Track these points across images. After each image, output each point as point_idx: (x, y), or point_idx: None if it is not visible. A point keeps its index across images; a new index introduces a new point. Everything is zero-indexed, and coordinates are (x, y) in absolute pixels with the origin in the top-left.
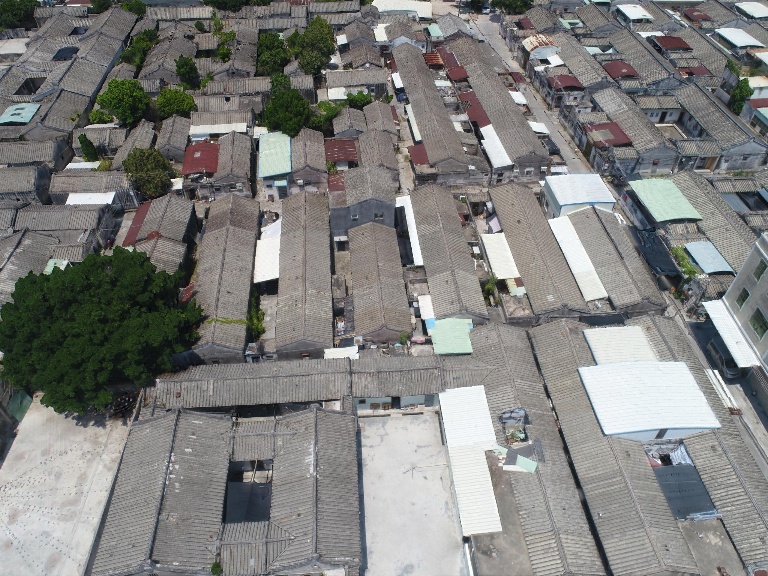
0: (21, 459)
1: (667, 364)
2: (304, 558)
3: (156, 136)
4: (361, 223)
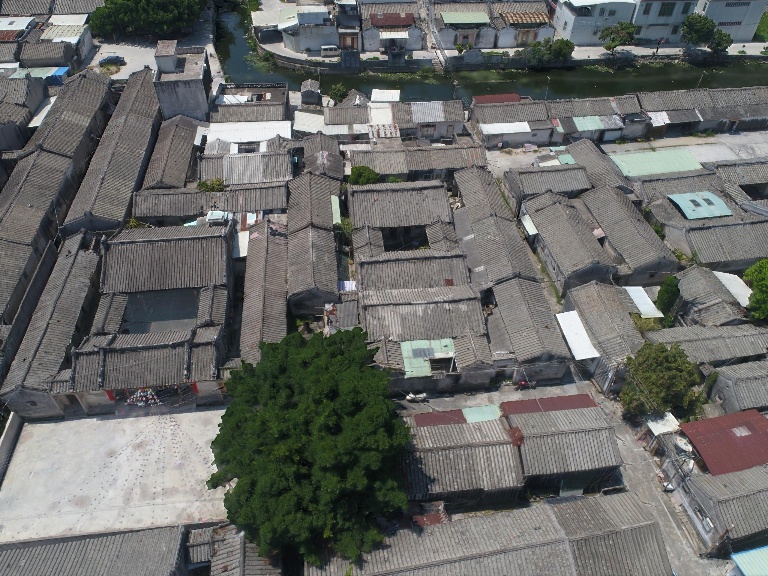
0: (205, 425)
1: None
2: None
3: (761, 358)
4: None
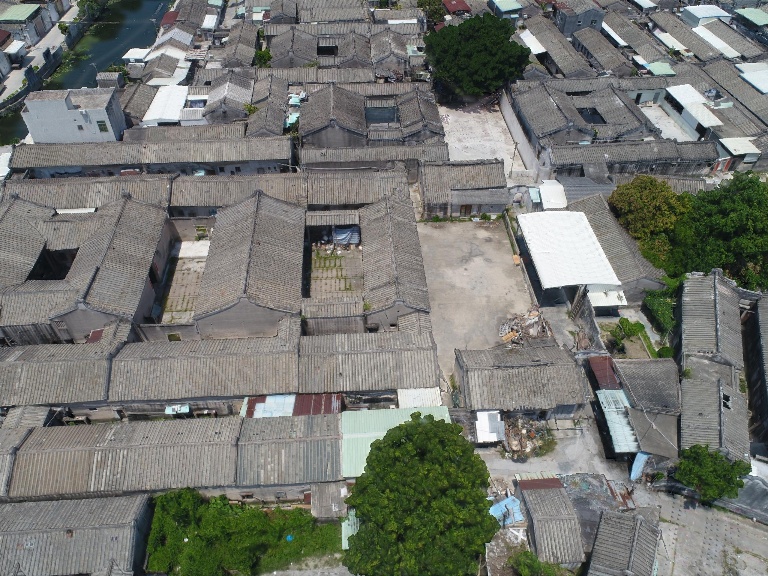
0: (445, 124)
1: None
2: None
3: None
4: (582, 28)
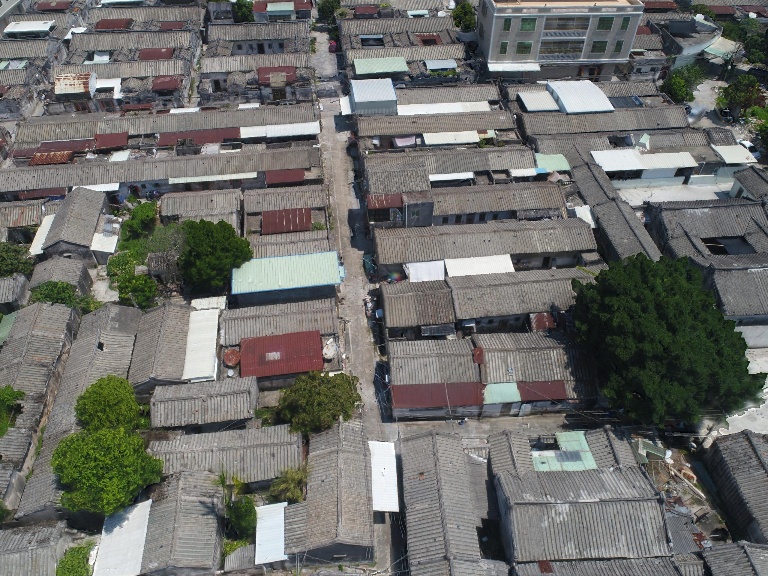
0: None
1: (552, 86)
2: (763, 210)
3: None
4: None
